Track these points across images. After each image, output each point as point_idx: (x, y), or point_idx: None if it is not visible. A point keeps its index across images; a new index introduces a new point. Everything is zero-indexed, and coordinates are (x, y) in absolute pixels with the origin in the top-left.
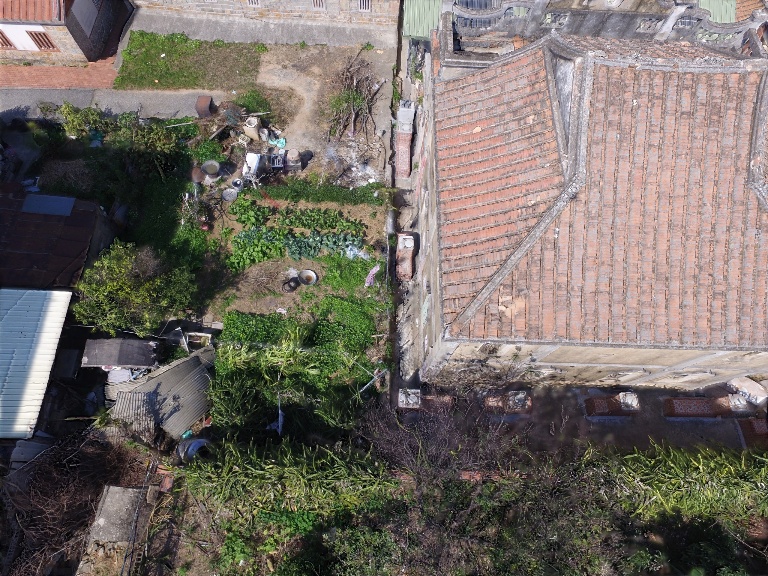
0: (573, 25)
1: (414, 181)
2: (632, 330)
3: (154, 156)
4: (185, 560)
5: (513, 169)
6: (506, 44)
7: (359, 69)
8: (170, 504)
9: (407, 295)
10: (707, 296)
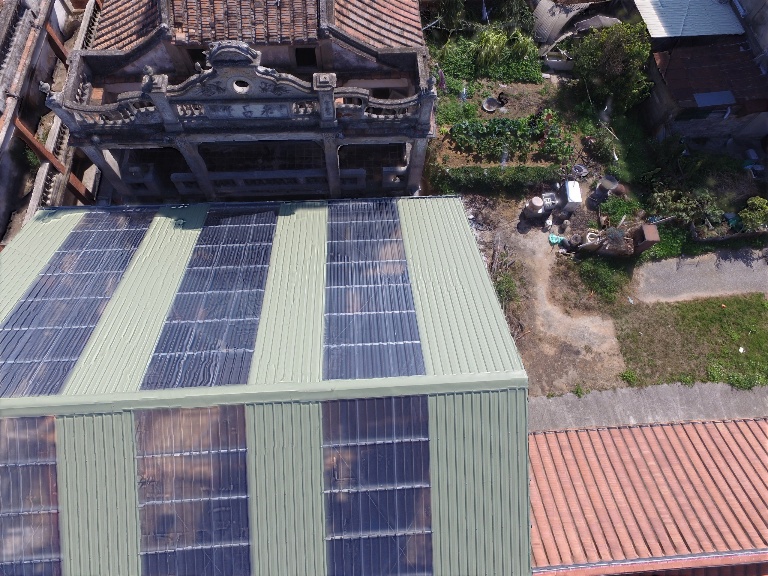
0: None
1: None
2: None
3: None
4: None
5: None
6: None
7: None
8: None
9: None
10: None
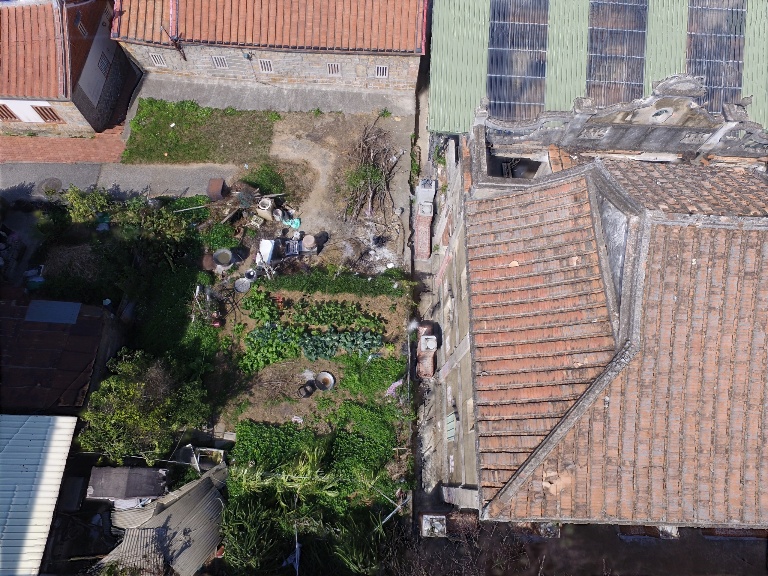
0: (613, 137)
1: (434, 265)
2: (689, 509)
3: (163, 245)
4: None
5: (556, 319)
6: (540, 151)
7: (376, 139)
8: None
9: (428, 394)
10: None
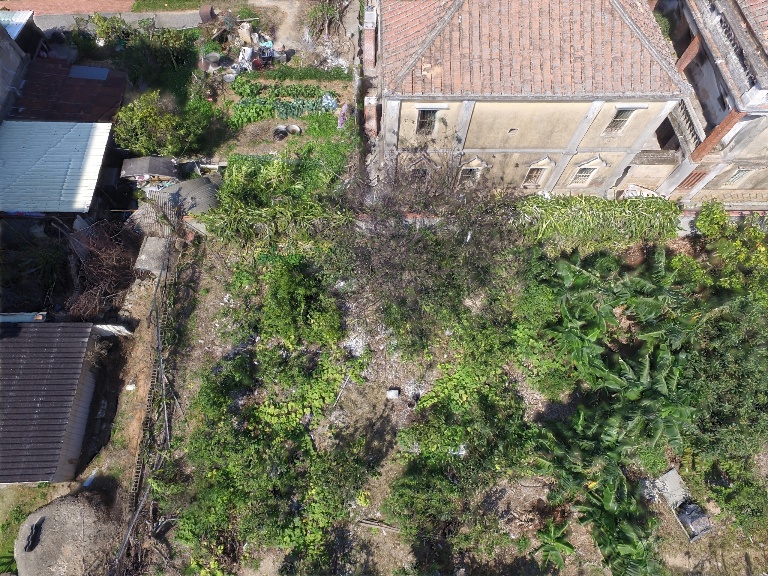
0: None
1: (378, 69)
2: (517, 85)
3: (168, 50)
4: (205, 287)
5: None
6: None
7: None
8: (193, 253)
9: (374, 148)
10: (570, 61)
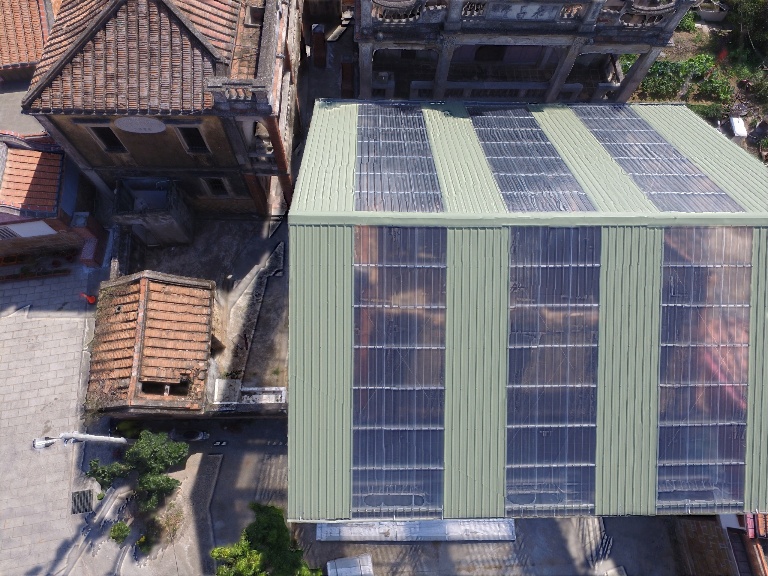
0: None
1: None
2: None
3: None
4: None
5: None
6: None
7: None
8: None
9: None
10: None
